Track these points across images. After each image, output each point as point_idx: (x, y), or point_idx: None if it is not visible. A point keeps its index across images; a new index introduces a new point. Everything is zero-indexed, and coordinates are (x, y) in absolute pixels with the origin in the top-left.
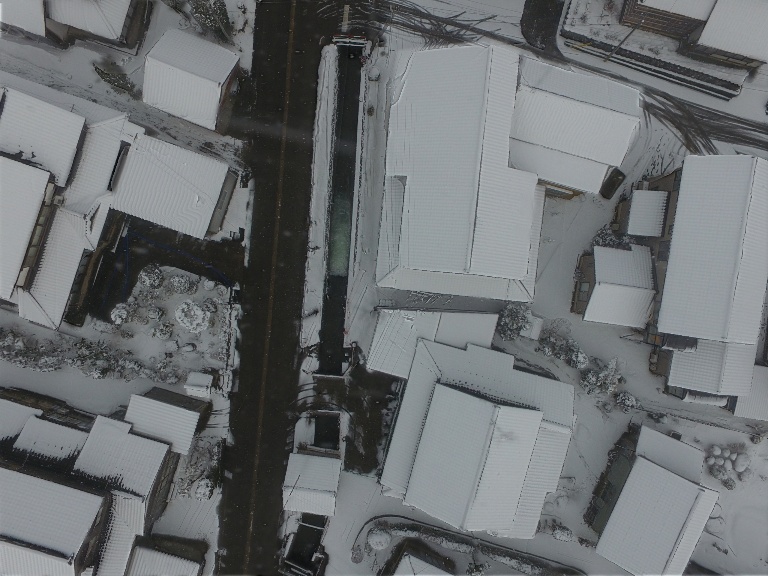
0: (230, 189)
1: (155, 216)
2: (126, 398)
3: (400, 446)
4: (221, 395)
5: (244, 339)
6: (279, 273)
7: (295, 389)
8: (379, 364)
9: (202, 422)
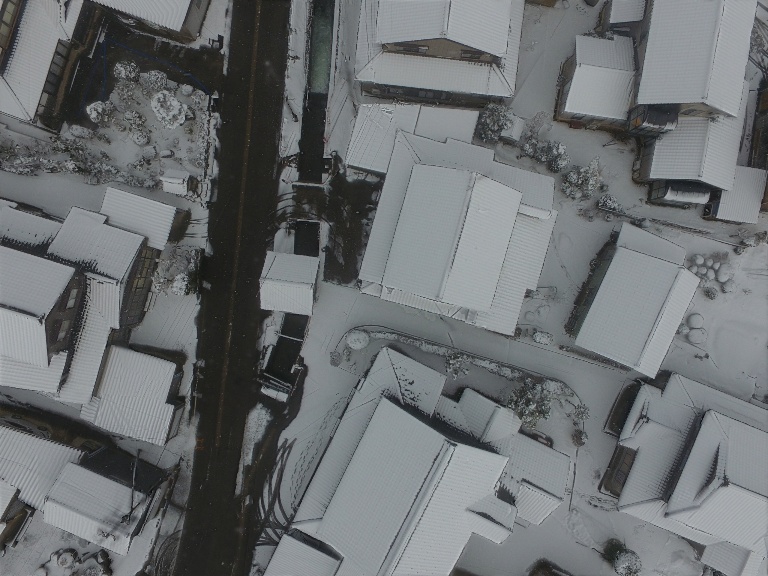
0: None
1: (130, 1)
2: None
3: (378, 238)
4: (199, 203)
5: (223, 148)
6: (258, 81)
7: (274, 199)
8: (358, 159)
9: (180, 231)
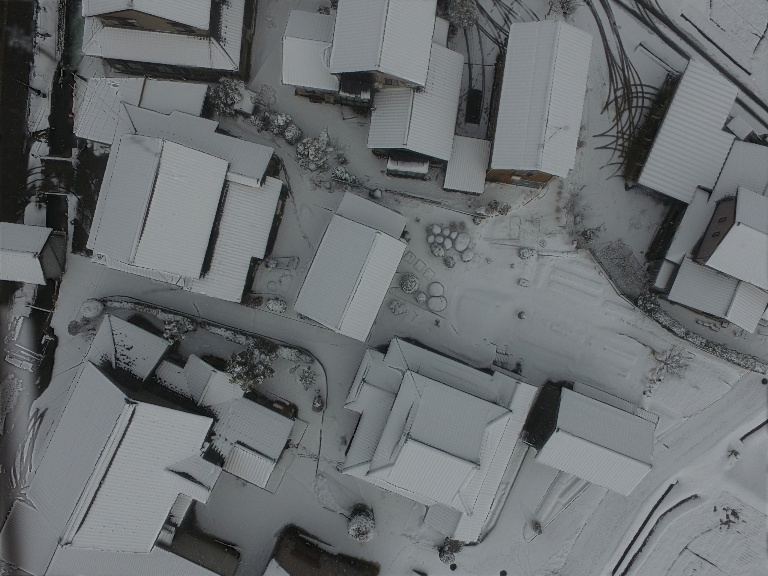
0: None
1: None
2: None
3: (102, 207)
4: None
5: None
6: (8, 58)
7: (24, 173)
8: (86, 131)
9: None
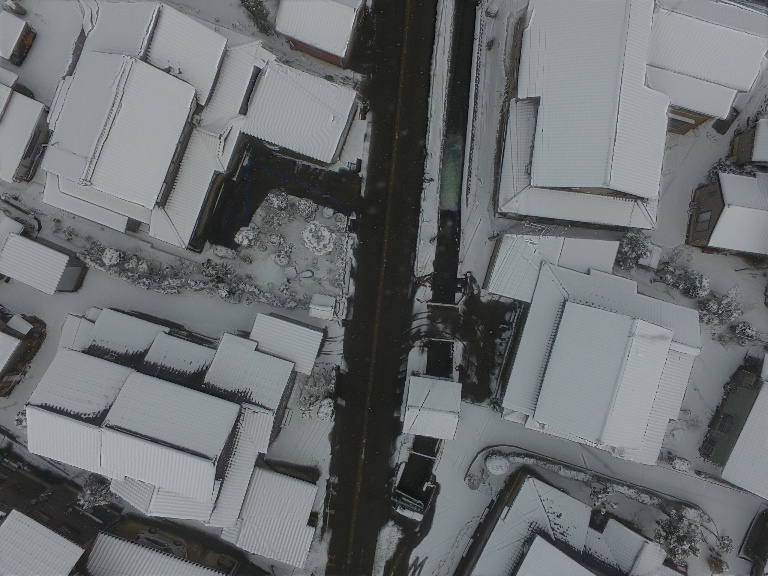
0: (350, 119)
1: (287, 137)
2: (243, 323)
3: (524, 368)
4: (337, 322)
5: (359, 268)
6: (395, 203)
7: (409, 318)
8: (501, 288)
9: None
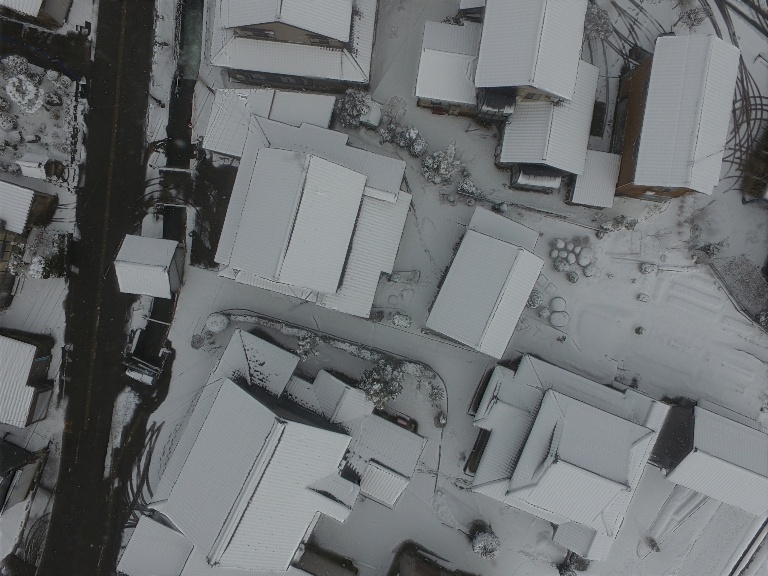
0: None
1: None
2: None
3: (232, 221)
4: (66, 188)
5: (90, 134)
6: (126, 67)
7: (142, 184)
8: (214, 143)
9: (48, 216)
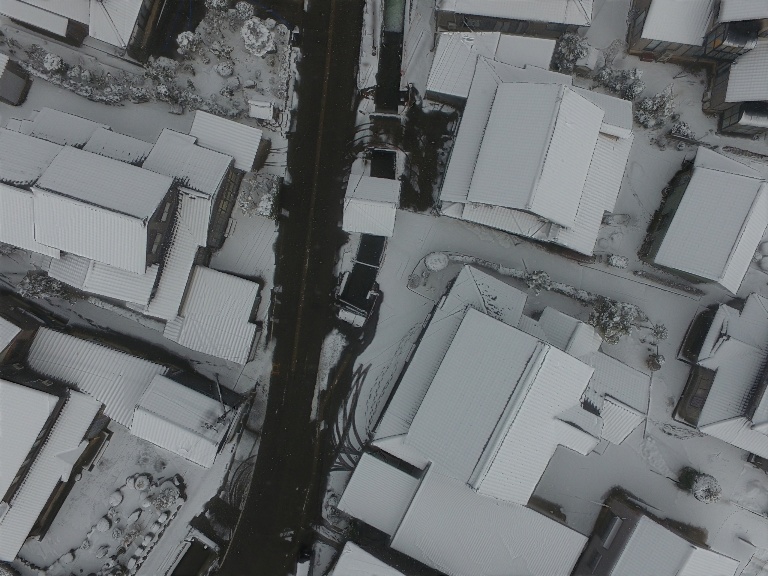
0: None
1: None
2: None
3: (460, 159)
4: (280, 133)
5: (303, 81)
6: (338, 17)
7: (352, 130)
8: (439, 85)
9: (260, 159)
